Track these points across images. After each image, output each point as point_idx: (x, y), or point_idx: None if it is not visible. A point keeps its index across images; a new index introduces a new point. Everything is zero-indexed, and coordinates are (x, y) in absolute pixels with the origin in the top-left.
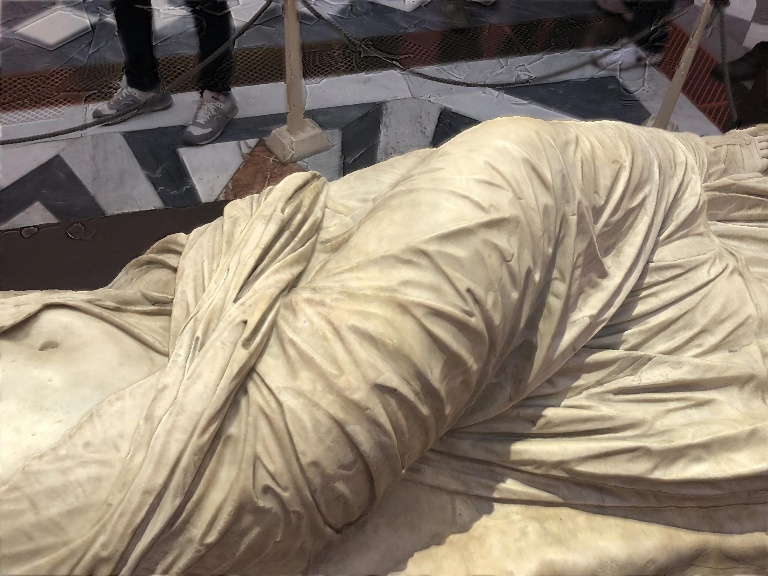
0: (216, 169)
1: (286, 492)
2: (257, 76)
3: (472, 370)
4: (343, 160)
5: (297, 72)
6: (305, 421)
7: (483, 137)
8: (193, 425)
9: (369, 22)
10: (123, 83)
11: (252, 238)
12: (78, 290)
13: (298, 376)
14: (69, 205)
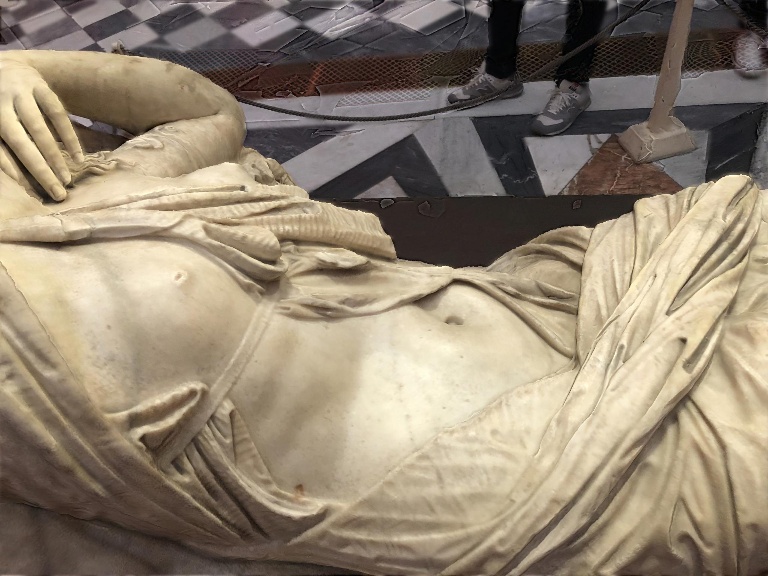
0: (562, 162)
1: (708, 548)
2: (614, 68)
3: None
4: (707, 165)
5: (676, 64)
6: (754, 474)
7: None
8: (614, 442)
9: (752, 11)
10: (481, 69)
11: (685, 244)
12: None
13: (751, 418)
14: (417, 182)
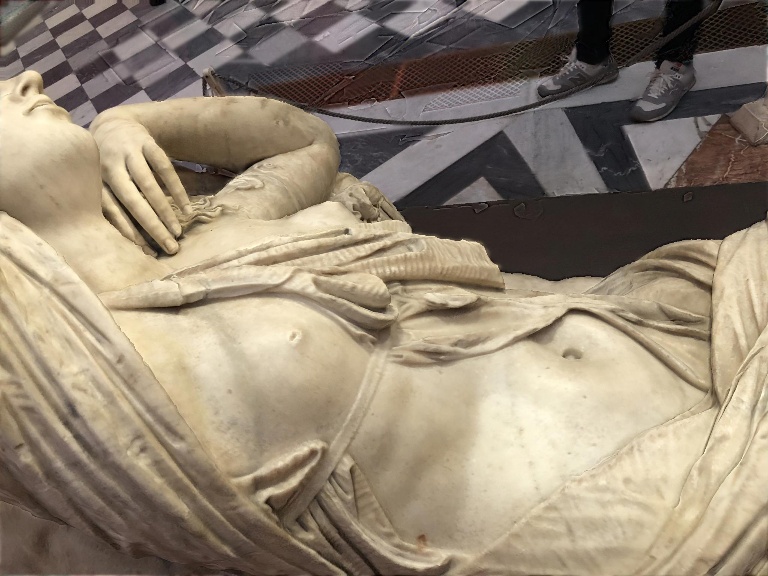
0: (667, 149)
1: None
2: (720, 40)
3: None
4: None
5: None
6: None
7: None
8: None
9: None
10: (572, 57)
11: None
12: (526, 271)
13: None
14: (510, 182)
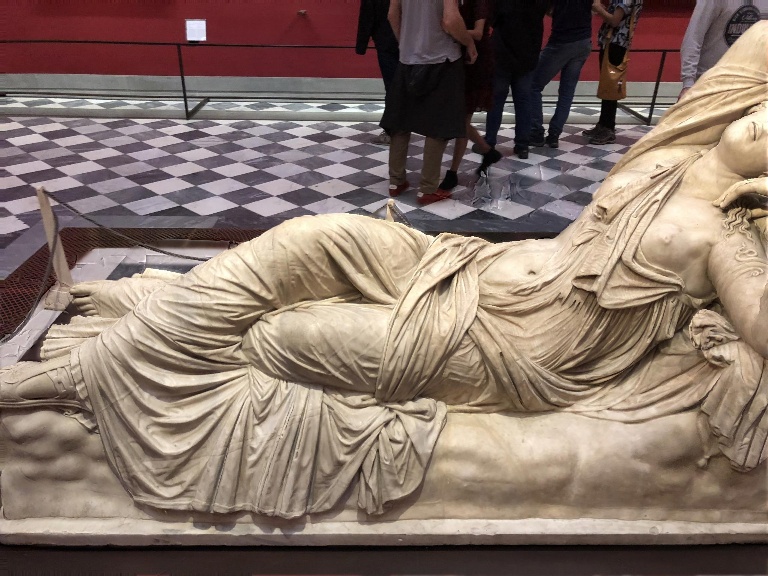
0: None
1: None
2: None
3: None
4: None
5: None
6: None
7: (319, 221)
8: None
9: None
10: None
11: (438, 269)
12: None
13: None
14: None
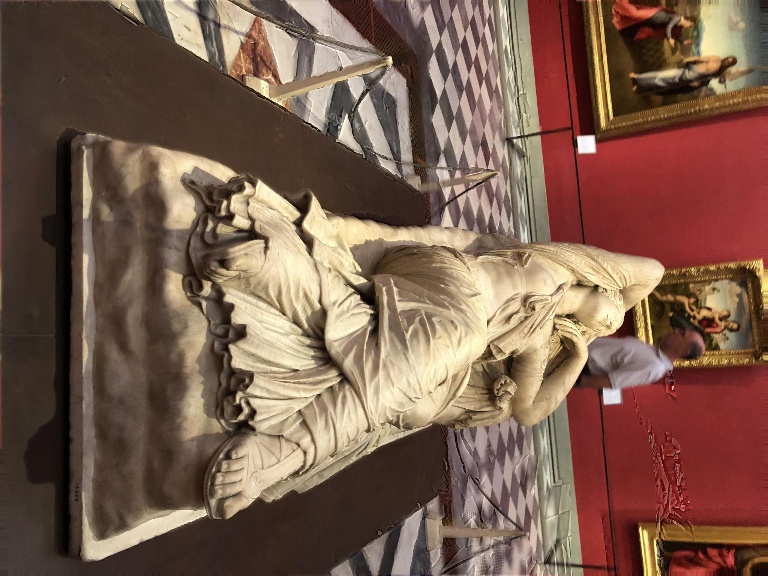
0: None
1: None
2: None
3: (435, 263)
4: None
5: None
6: None
7: None
8: None
9: None
10: None
11: None
12: (378, 471)
13: None
14: None
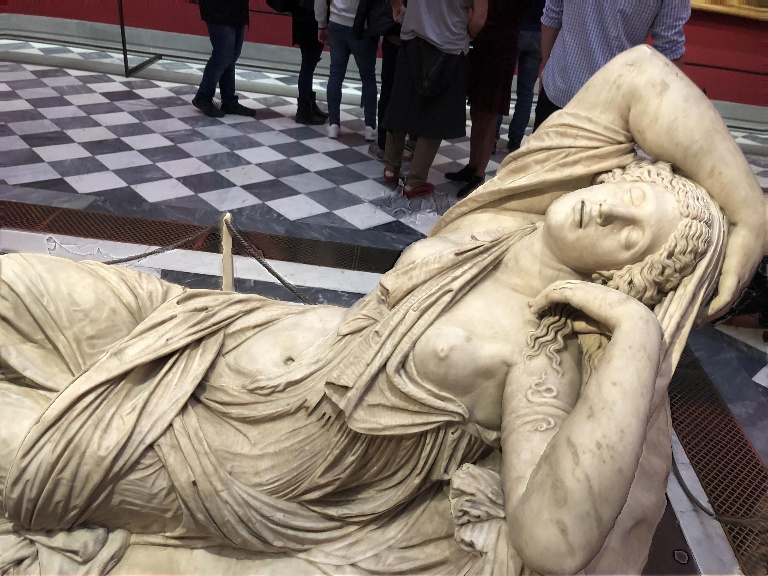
0: None
1: None
2: None
3: None
4: None
5: None
6: None
7: None
8: None
9: None
10: None
11: (140, 348)
12: None
13: (168, 285)
14: None
